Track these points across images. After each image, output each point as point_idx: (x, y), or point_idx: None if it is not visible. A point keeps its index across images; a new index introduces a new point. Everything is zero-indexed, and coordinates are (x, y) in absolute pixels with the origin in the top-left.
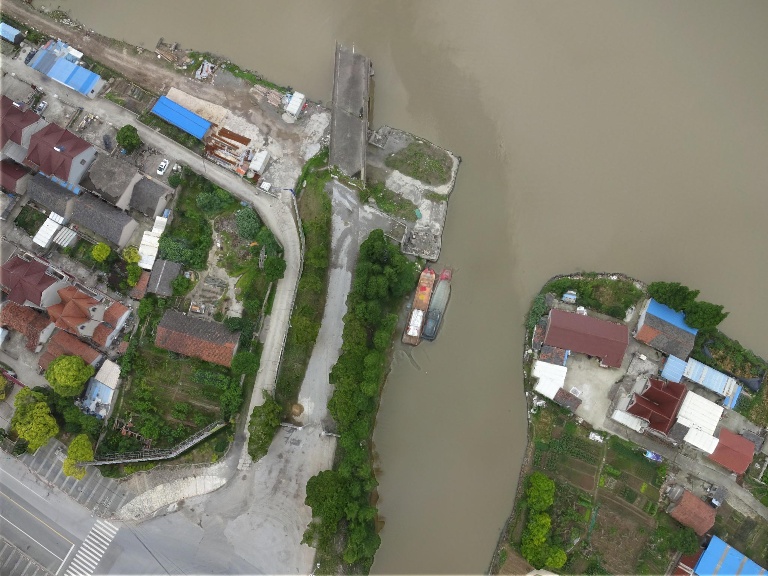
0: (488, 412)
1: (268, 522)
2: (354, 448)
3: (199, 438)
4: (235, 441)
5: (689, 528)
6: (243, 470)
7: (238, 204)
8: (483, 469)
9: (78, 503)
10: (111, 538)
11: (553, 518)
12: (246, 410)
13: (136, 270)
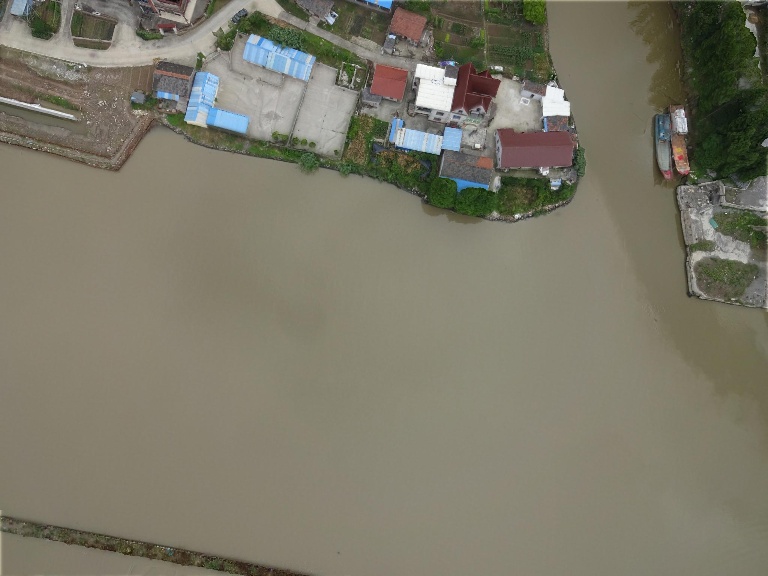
0: (582, 74)
1: None
2: None
3: None
4: None
5: (414, 7)
6: None
7: None
8: (571, 27)
9: None
10: None
11: None
12: None
13: None
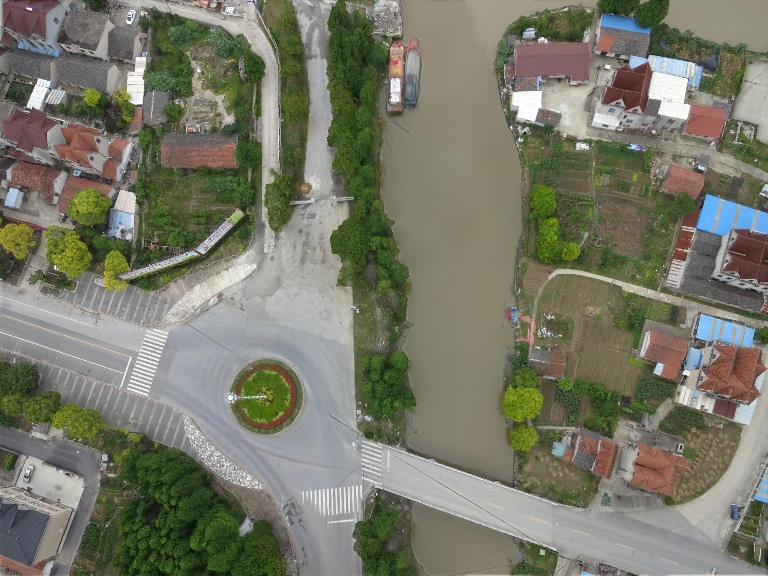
0: (481, 158)
1: (303, 290)
2: (364, 187)
3: (222, 228)
4: (256, 230)
5: (683, 192)
6: (270, 252)
7: (208, 30)
8: (488, 207)
9: (126, 321)
10: (163, 342)
11: (560, 222)
12: (259, 202)
13: (128, 105)
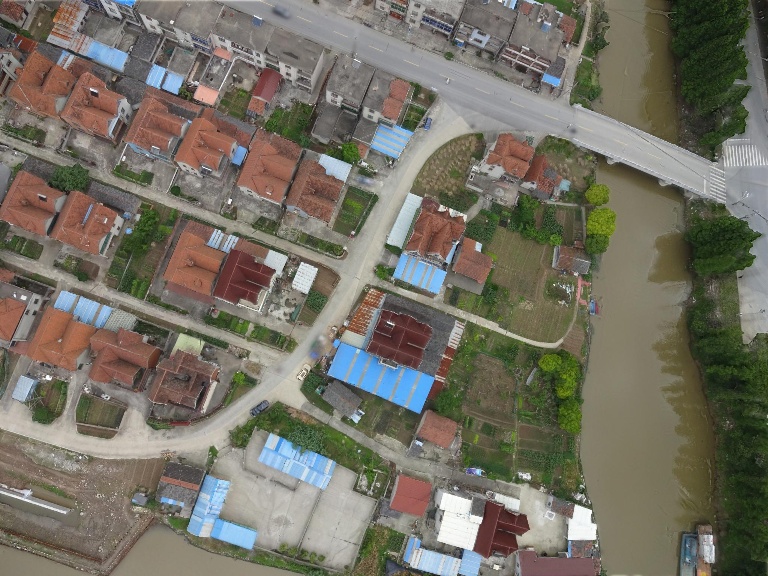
0: (610, 473)
1: None
2: (765, 428)
3: None
4: None
5: None
6: None
7: None
8: (604, 419)
9: None
10: None
11: (553, 395)
12: None
13: None
